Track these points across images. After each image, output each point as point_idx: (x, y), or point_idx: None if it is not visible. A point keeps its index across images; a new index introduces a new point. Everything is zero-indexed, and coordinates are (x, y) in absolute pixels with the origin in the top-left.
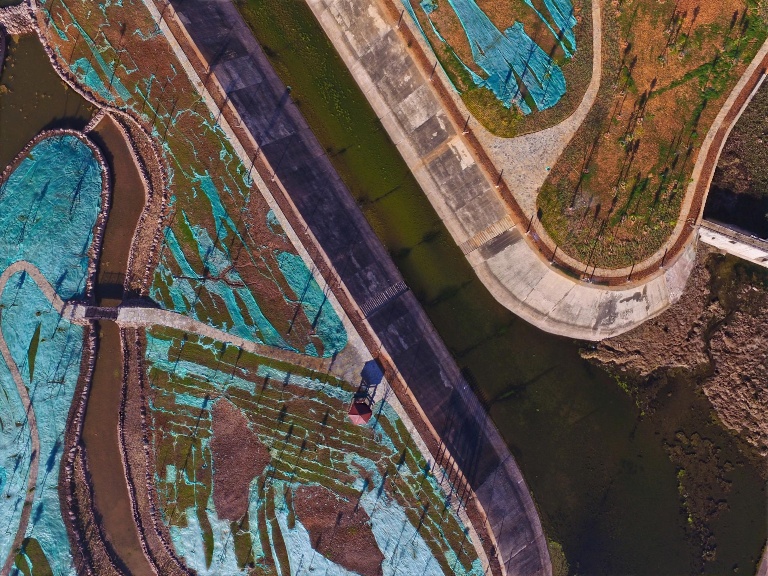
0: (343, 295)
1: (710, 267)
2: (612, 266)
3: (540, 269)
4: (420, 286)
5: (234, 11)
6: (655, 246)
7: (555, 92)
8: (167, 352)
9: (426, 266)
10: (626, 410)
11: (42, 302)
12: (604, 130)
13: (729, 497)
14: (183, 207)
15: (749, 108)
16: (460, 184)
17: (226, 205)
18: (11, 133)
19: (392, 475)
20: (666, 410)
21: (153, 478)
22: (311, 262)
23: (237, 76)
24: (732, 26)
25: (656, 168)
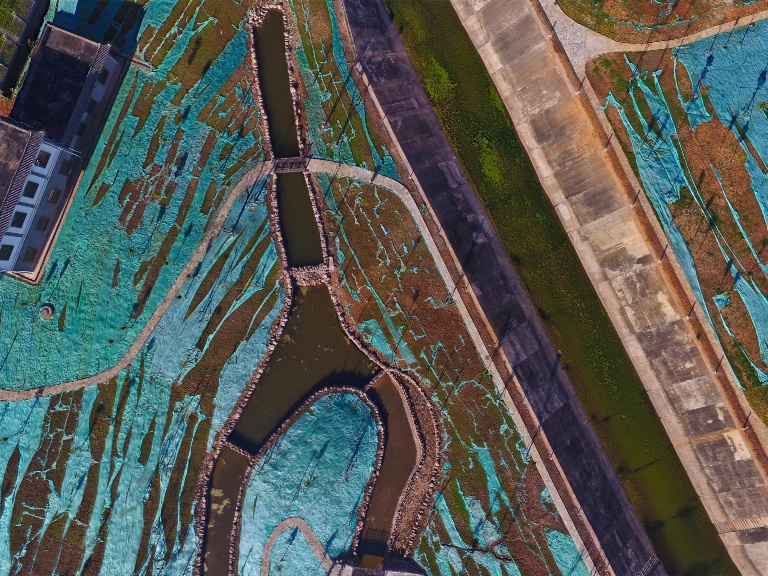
0: None
1: None
2: None
3: None
4: (671, 560)
5: (513, 273)
6: None
7: None
8: None
9: (679, 540)
10: None
11: (311, 560)
12: None
13: None
14: (458, 476)
15: None
16: (729, 472)
17: (502, 479)
18: (289, 381)
19: None
20: None
21: None
22: (581, 543)
23: (519, 347)
24: None
25: None
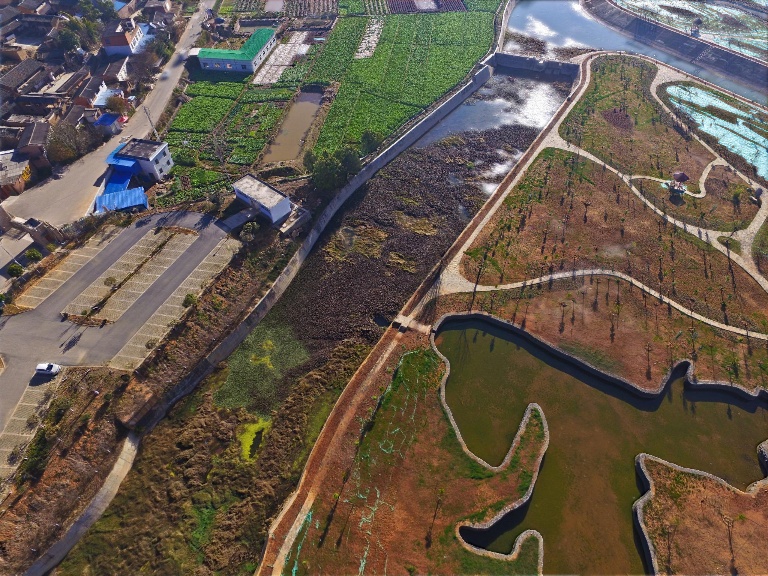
0: None
1: None
2: None
3: None
4: None
5: None
6: None
7: None
8: None
9: None
10: None
11: None
12: None
13: None
14: None
15: (560, 103)
16: None
17: None
18: None
19: None
20: None
21: (760, 21)
22: None
23: None
24: None
25: None
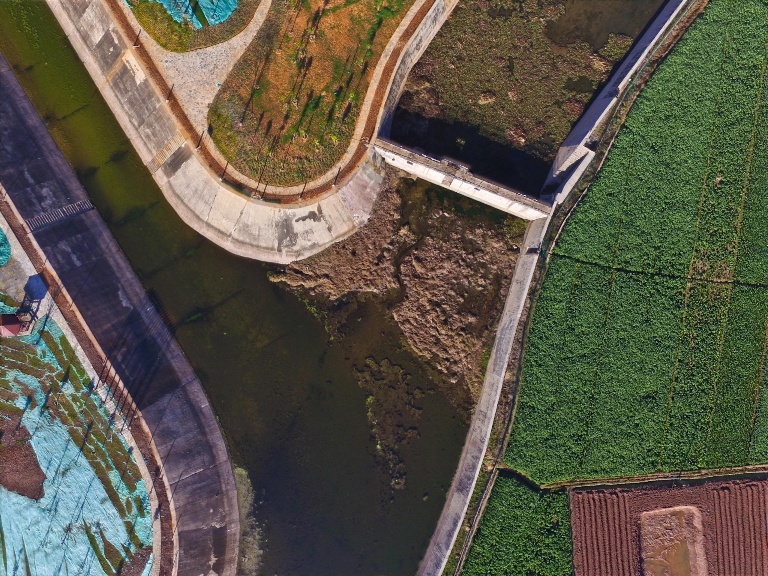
0: (7, 208)
1: (401, 192)
2: (284, 184)
3: (212, 186)
4: (106, 206)
5: None
6: (328, 164)
7: (226, 7)
8: None
9: (113, 186)
10: (316, 335)
11: None
12: (276, 46)
13: (420, 425)
14: None
15: (442, 33)
16: (138, 100)
17: None
18: None
19: (56, 393)
20: (356, 335)
21: None
22: None
23: None
24: None
25: (329, 86)
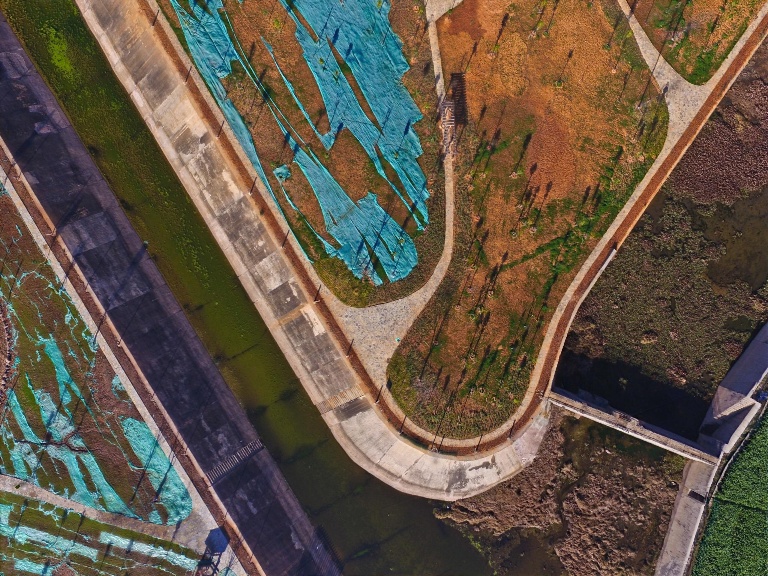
0: (189, 462)
1: (564, 429)
2: (460, 436)
3: (389, 438)
4: (276, 444)
5: (90, 164)
6: (503, 417)
7: (406, 264)
8: (7, 517)
9: (282, 424)
10: (479, 569)
11: None
12: (455, 302)
13: None
14: (26, 370)
15: (606, 274)
16: (313, 349)
17: (70, 370)
18: None
19: None
20: (519, 569)
21: None
22: (157, 429)
23: (87, 236)
24: (584, 201)
25: (506, 340)
